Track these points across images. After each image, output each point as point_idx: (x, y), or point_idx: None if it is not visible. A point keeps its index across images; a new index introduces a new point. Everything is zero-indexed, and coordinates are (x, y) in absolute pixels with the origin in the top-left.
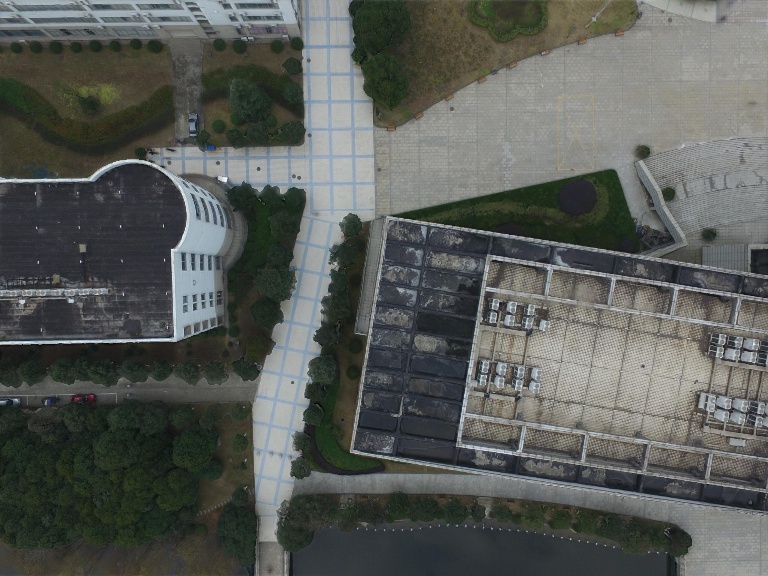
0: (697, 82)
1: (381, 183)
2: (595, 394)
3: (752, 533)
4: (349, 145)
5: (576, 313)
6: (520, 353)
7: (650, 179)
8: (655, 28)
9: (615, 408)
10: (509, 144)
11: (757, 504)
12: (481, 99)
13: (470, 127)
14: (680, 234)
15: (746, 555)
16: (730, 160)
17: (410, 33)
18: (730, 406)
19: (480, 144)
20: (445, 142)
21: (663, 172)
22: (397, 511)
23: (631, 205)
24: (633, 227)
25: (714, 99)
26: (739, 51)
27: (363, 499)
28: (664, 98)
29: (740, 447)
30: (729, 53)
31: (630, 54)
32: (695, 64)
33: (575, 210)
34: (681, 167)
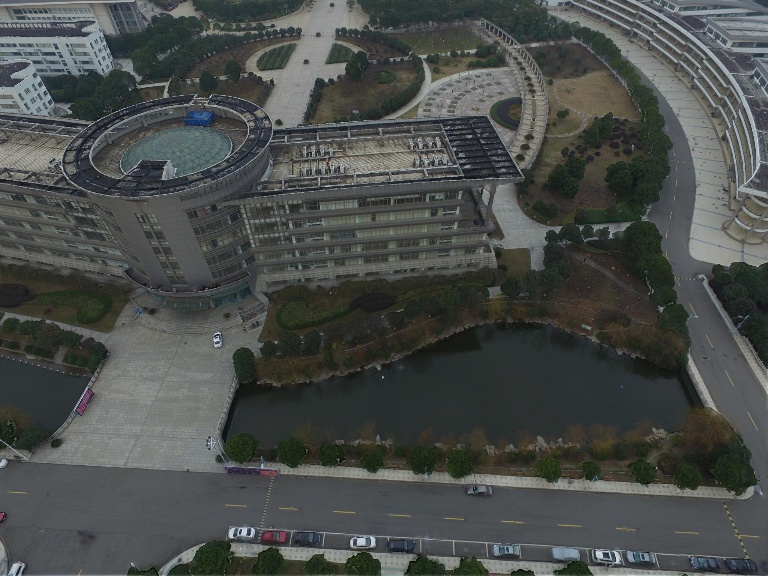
0: None
1: None
2: (3, 163)
3: (166, 360)
4: None
5: None
6: None
7: None
8: None
9: None
10: None
11: None
12: None
13: None
14: None
15: (153, 376)
16: None
17: None
18: None
19: None
20: None
21: None
22: None
23: None
24: None
25: None
26: None
27: None
28: None
29: None
30: None
31: None
32: None
33: None
34: None
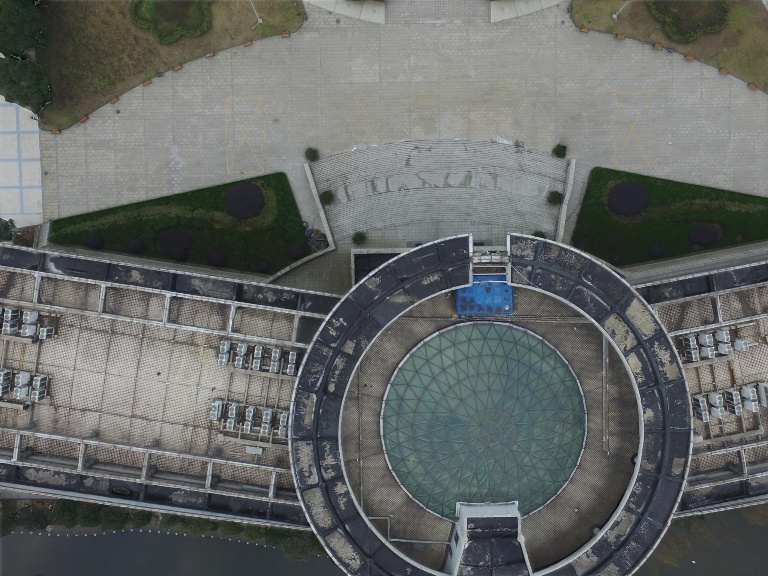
0: (367, 84)
1: (48, 187)
2: (111, 402)
3: None
4: (15, 149)
5: (89, 320)
6: (32, 360)
7: (310, 182)
8: (323, 30)
9: (132, 416)
10: (177, 147)
11: (265, 513)
12: (148, 102)
13: (137, 130)
14: (328, 238)
15: None
16: (396, 163)
17: (72, 35)
18: (234, 414)
19: (148, 147)
20: (112, 145)
21: (329, 175)
22: (55, 517)
23: (303, 208)
24: (302, 231)
25: (385, 101)
26: (409, 52)
27: (38, 504)
28: (334, 100)
29: (263, 455)
30: (399, 55)
31: (298, 56)
32: (365, 66)
33: (241, 214)
34: (347, 170)
